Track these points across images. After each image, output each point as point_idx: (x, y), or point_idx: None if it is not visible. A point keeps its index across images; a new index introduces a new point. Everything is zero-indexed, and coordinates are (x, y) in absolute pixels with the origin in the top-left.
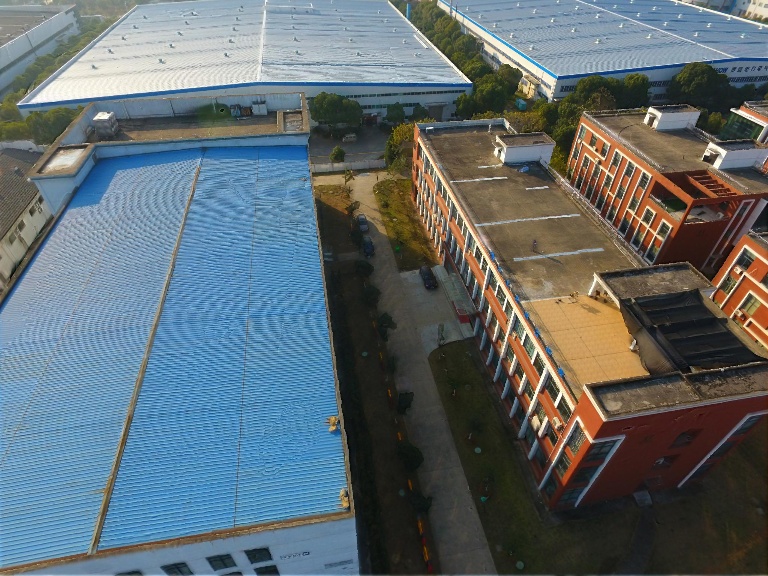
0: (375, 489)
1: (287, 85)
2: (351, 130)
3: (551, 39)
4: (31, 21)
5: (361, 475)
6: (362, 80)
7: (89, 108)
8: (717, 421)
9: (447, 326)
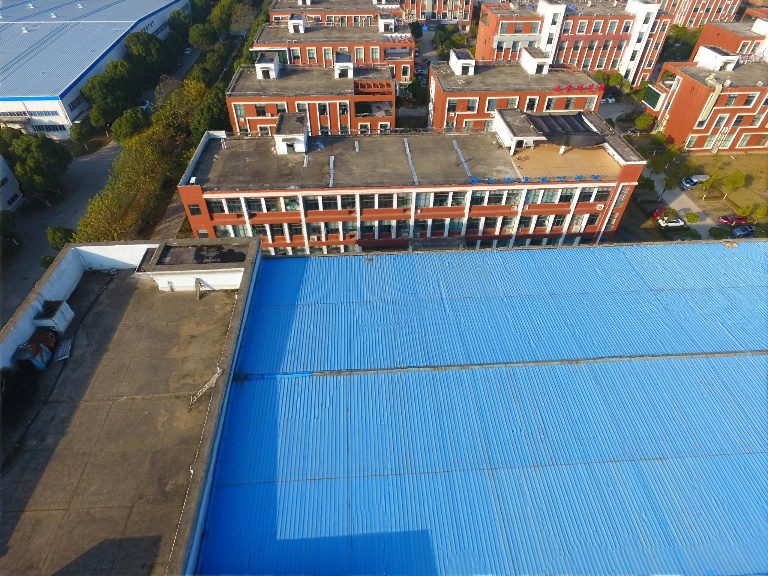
0: None
1: None
2: None
3: None
4: None
5: None
6: None
7: None
8: None
9: None
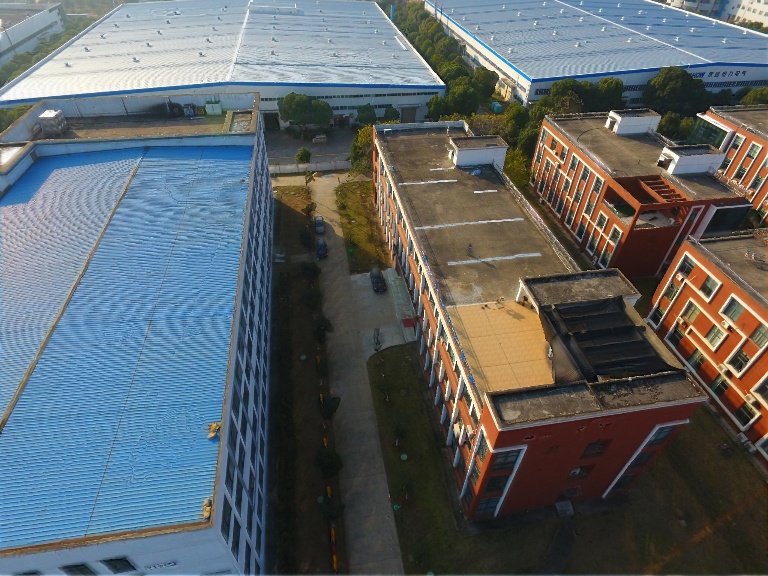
0: (291, 496)
1: (257, 85)
2: (322, 131)
3: (531, 42)
4: (14, 19)
5: (279, 481)
6: (334, 81)
7: (38, 106)
8: (627, 431)
9: (390, 330)
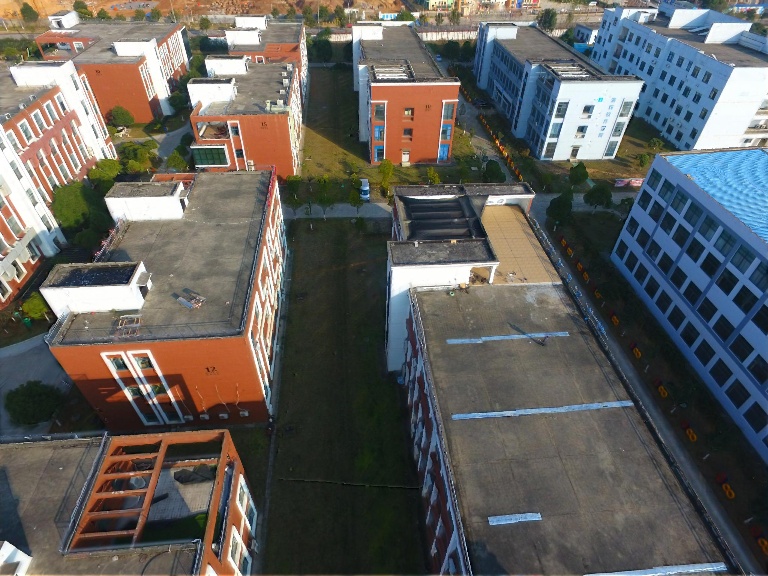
0: None
1: None
2: None
3: None
4: None
5: None
6: None
7: None
8: None
9: None
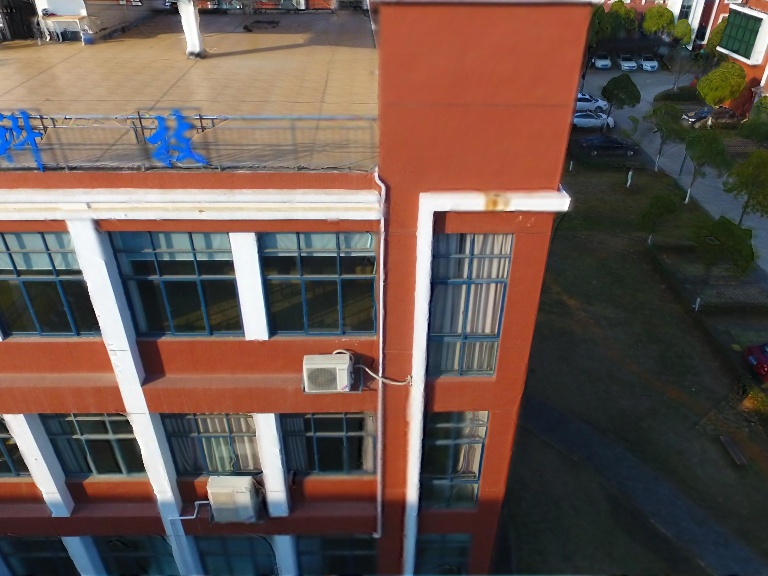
0: None
1: None
2: None
3: None
4: None
5: None
6: None
7: None
8: None
9: None
